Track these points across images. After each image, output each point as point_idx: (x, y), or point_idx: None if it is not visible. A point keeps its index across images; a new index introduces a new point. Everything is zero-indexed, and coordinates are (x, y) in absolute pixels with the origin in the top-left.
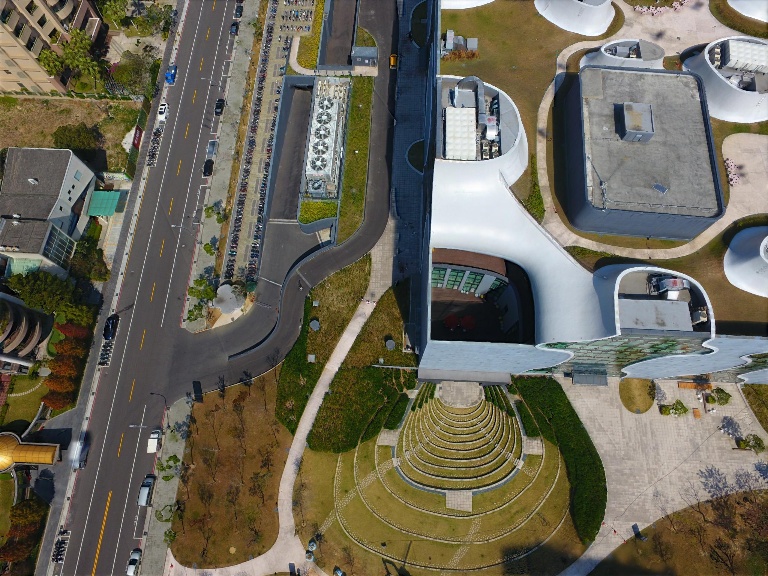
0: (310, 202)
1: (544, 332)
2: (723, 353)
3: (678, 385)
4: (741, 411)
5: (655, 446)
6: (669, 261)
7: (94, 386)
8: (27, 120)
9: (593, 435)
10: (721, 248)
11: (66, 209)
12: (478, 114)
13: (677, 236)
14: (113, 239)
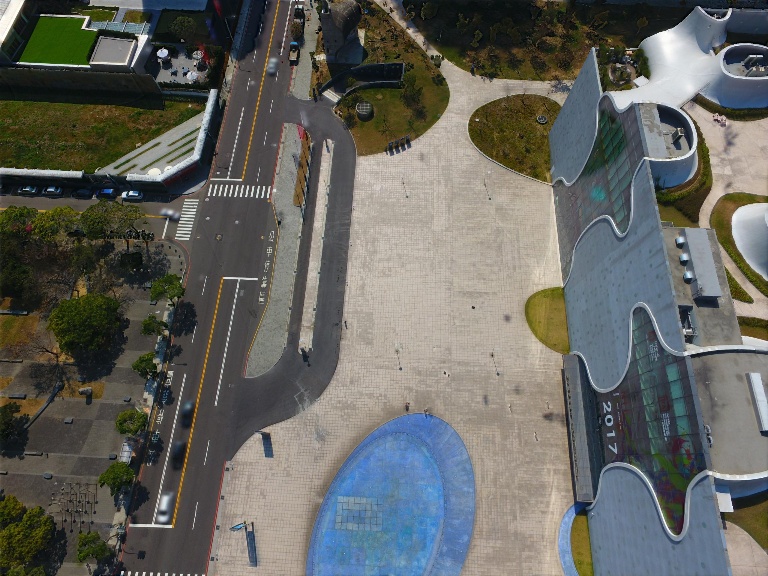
0: None
1: None
2: None
3: None
4: None
5: None
6: None
7: None
8: None
9: None
10: None
11: None
12: None
13: None
14: None
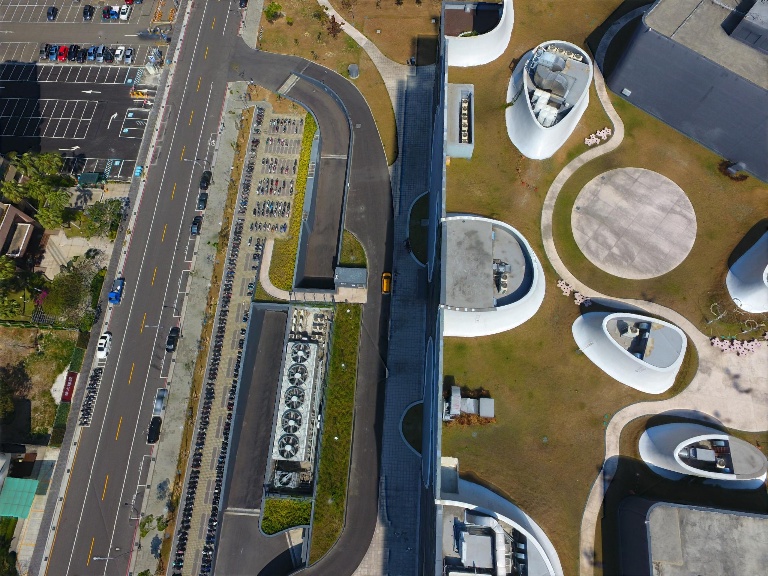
0: None
1: None
2: None
3: None
4: None
5: None
6: None
7: None
8: None
9: None
10: None
11: None
12: None
13: None
14: (30, 536)
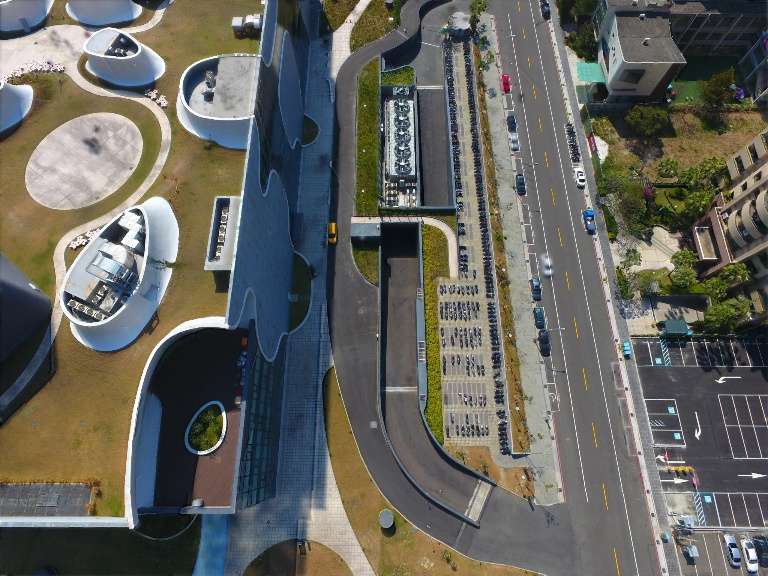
0: None
1: None
2: None
3: None
4: None
5: None
6: None
7: None
8: None
9: None
10: None
11: None
12: None
13: None
14: (574, 66)
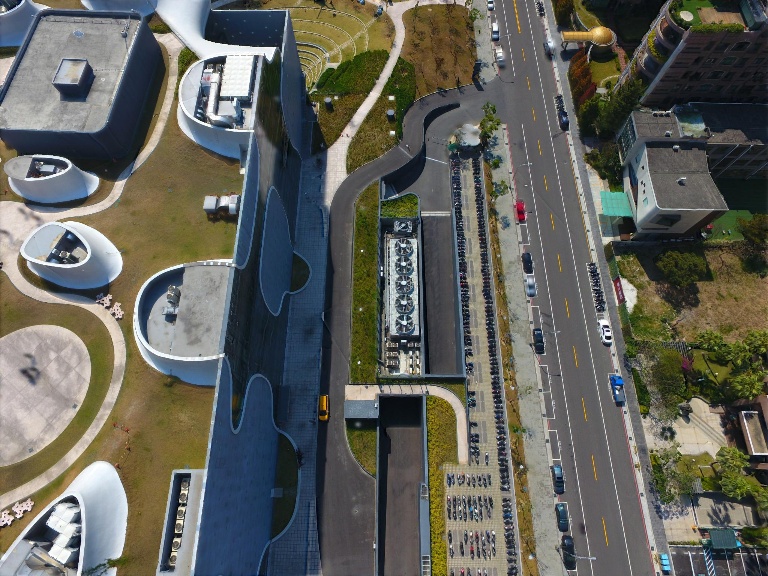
0: None
1: None
2: None
3: None
4: None
5: None
6: None
7: (559, 85)
8: (765, 315)
9: None
10: None
11: None
12: (218, 88)
13: None
14: (596, 189)
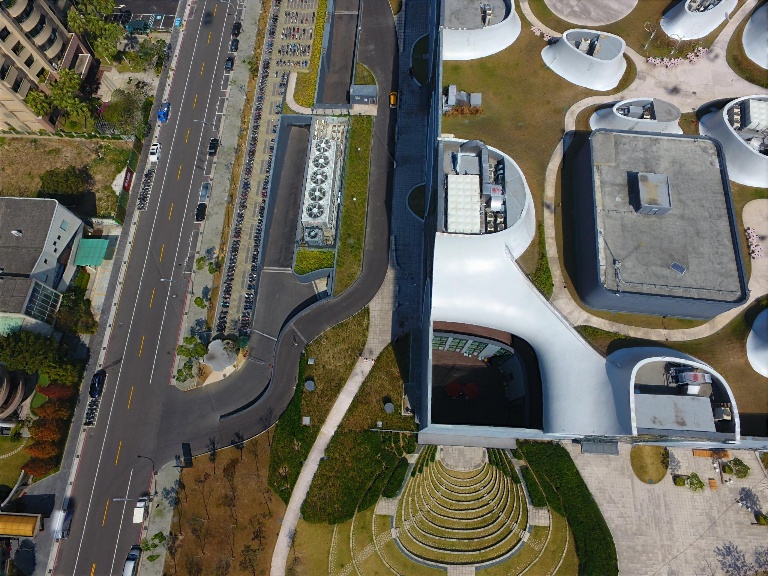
0: (306, 251)
1: (553, 421)
2: (746, 443)
3: (693, 453)
4: (760, 482)
5: (669, 520)
6: (687, 343)
7: (79, 448)
8: (15, 160)
9: (603, 508)
10: (743, 329)
11: (51, 261)
12: (482, 183)
13: (696, 316)
14: (101, 288)
